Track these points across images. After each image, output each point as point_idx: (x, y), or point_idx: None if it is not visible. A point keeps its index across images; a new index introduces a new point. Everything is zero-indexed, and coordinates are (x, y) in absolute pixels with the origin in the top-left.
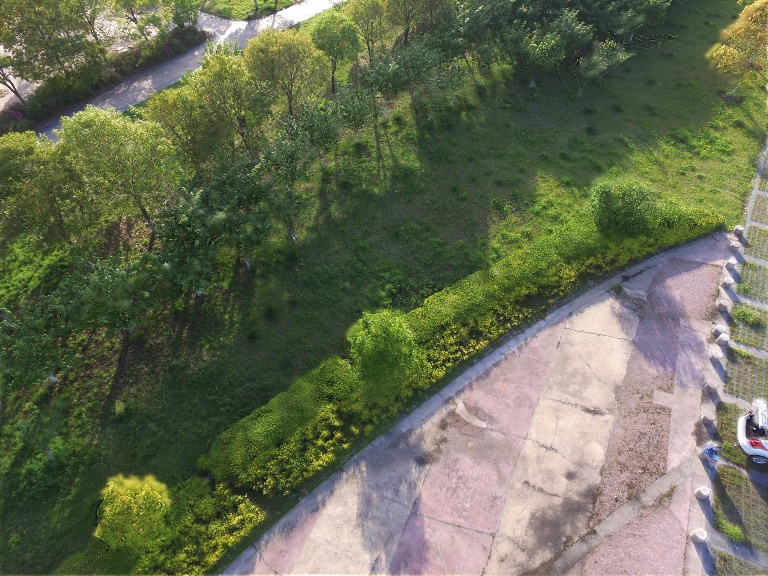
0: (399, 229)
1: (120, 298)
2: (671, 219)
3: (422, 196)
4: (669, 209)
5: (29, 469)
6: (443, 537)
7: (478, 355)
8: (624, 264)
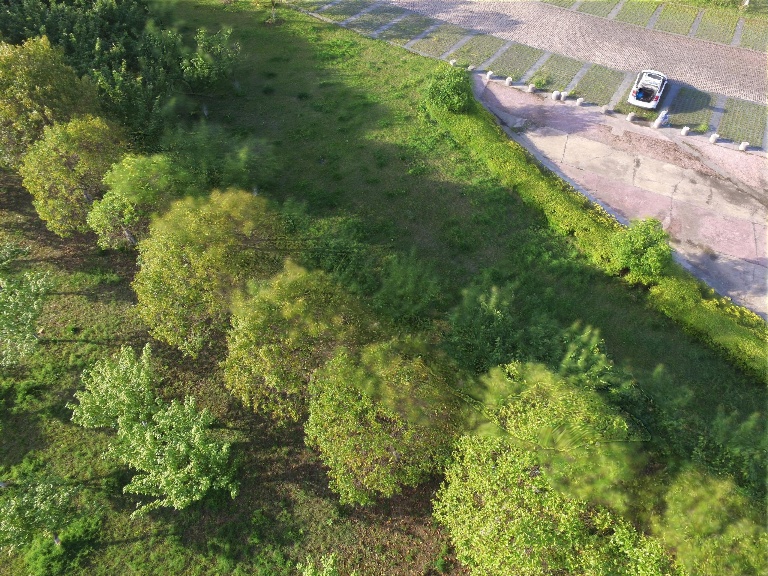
0: (459, 242)
1: None
2: None
3: (400, 221)
4: None
5: None
6: (767, 248)
7: None
8: None
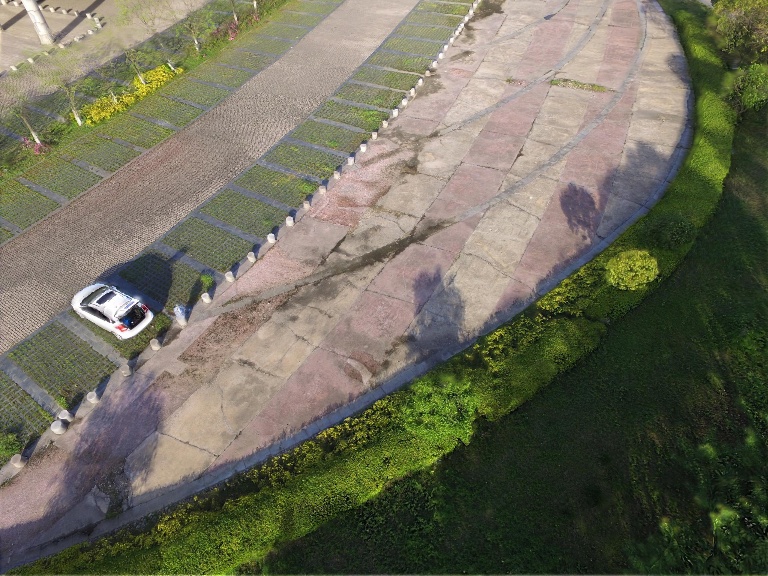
0: None
1: None
2: None
3: None
4: None
5: (760, 333)
6: (402, 291)
7: None
8: None
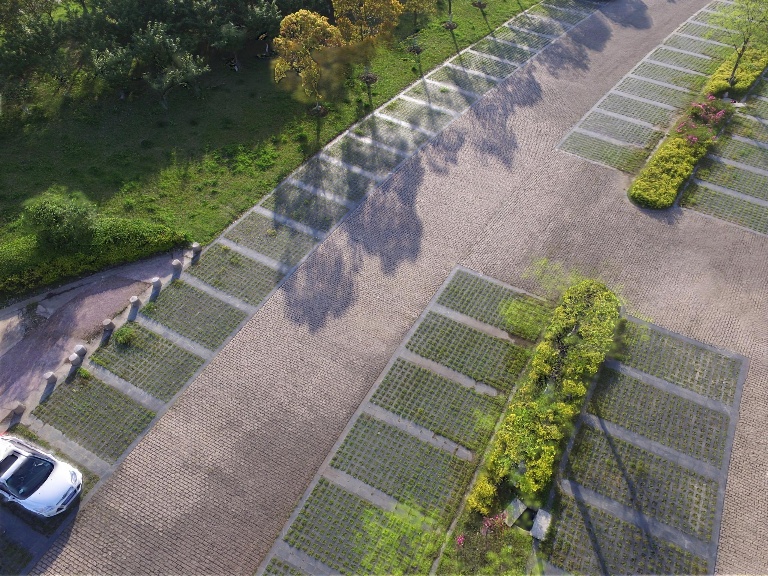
0: None
1: None
2: (120, 236)
3: None
4: (126, 226)
5: None
6: None
7: None
8: (51, 282)
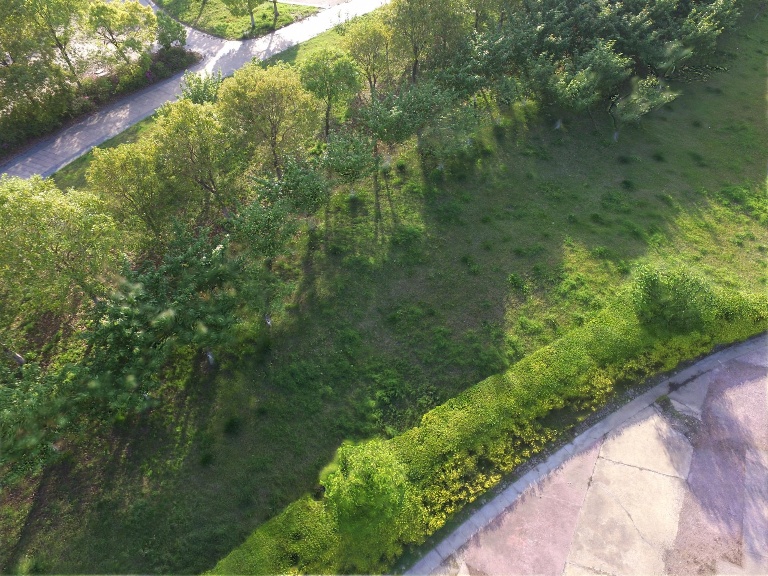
0: (396, 313)
1: (27, 432)
2: (730, 310)
3: (426, 268)
4: (727, 296)
5: None
6: None
7: (488, 494)
8: (672, 368)
